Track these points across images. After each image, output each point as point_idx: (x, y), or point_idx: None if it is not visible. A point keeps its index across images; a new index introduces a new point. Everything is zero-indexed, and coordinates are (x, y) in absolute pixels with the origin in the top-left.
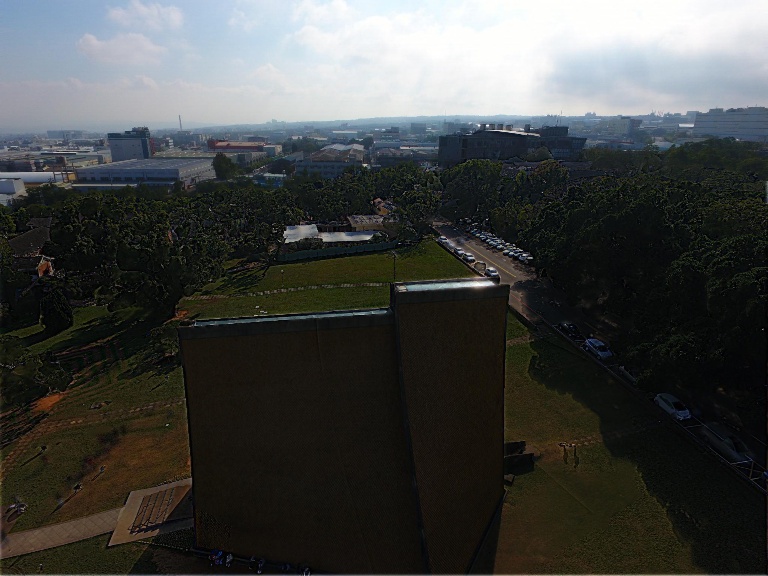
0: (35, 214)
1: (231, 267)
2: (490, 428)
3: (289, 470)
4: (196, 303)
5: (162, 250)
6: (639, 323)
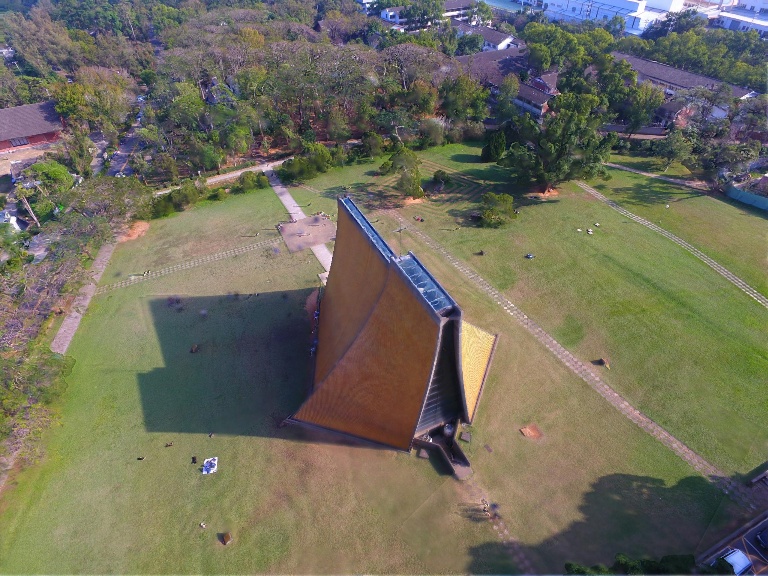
0: (626, 46)
1: (673, 175)
2: (405, 400)
3: (338, 305)
4: (576, 191)
5: (553, 133)
6: (698, 570)
